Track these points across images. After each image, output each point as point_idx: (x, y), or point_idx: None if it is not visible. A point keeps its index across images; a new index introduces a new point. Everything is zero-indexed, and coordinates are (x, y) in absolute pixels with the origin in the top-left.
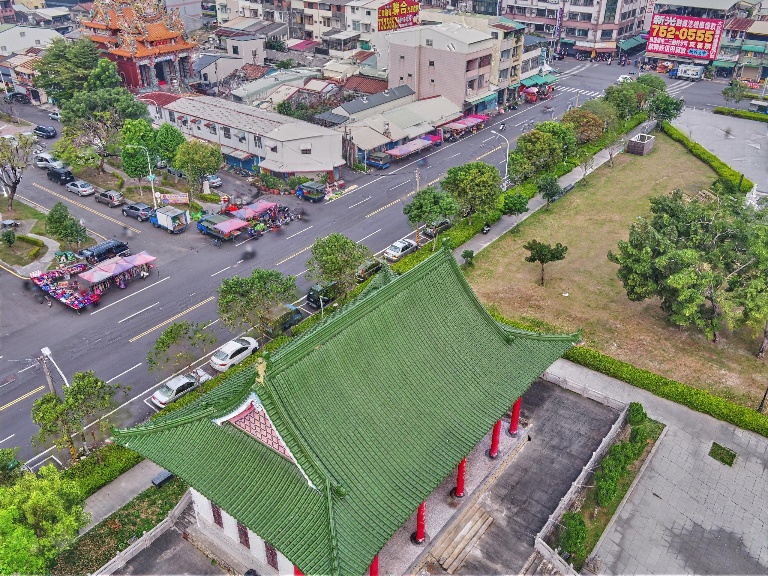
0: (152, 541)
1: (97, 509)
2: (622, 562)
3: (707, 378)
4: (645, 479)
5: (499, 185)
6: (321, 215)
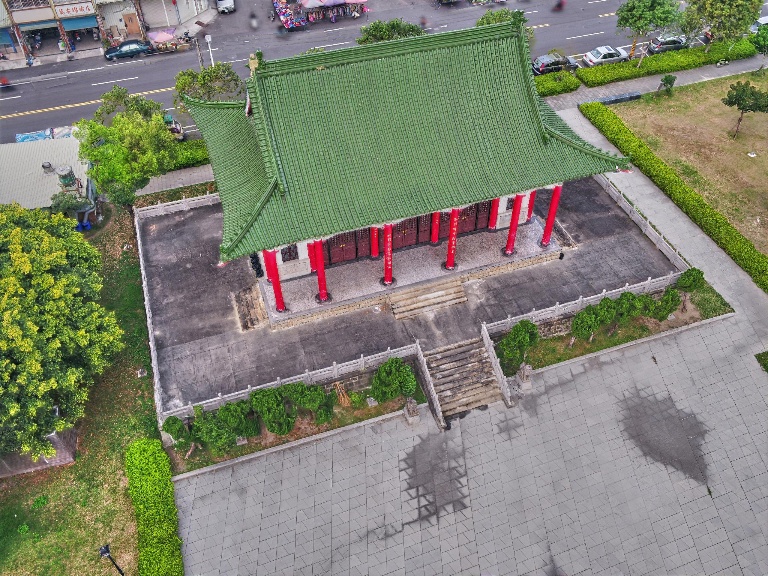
0: (215, 203)
1: (207, 174)
2: (562, 388)
3: None
4: (658, 342)
5: (757, 10)
6: (554, 3)
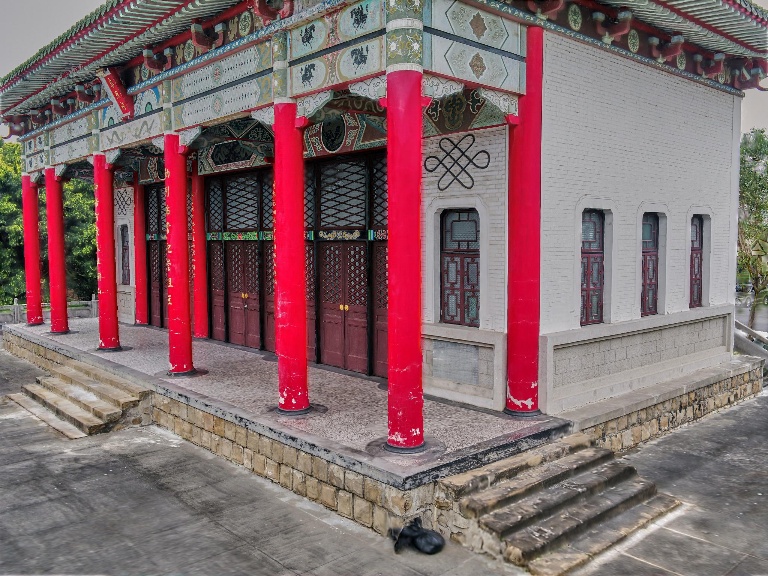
0: None
1: None
2: None
3: None
4: None
5: None
6: None
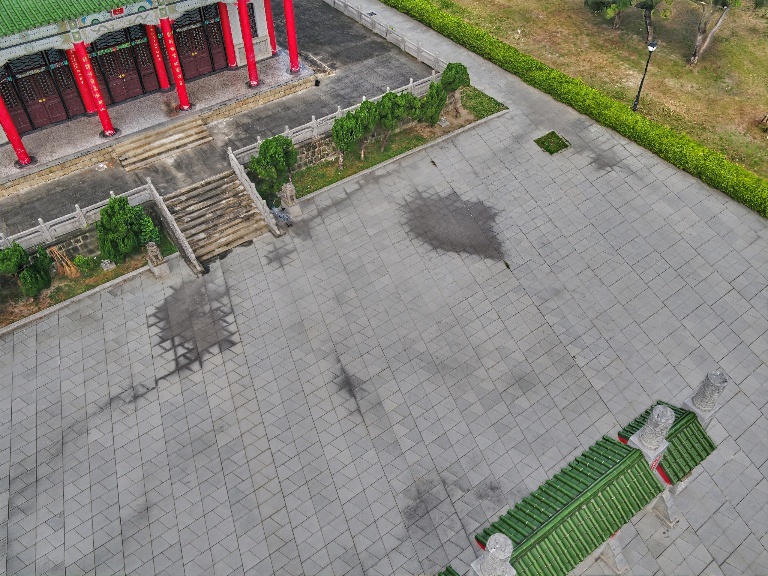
0: None
1: None
2: (337, 207)
3: (605, 76)
4: (435, 148)
5: None
6: None
